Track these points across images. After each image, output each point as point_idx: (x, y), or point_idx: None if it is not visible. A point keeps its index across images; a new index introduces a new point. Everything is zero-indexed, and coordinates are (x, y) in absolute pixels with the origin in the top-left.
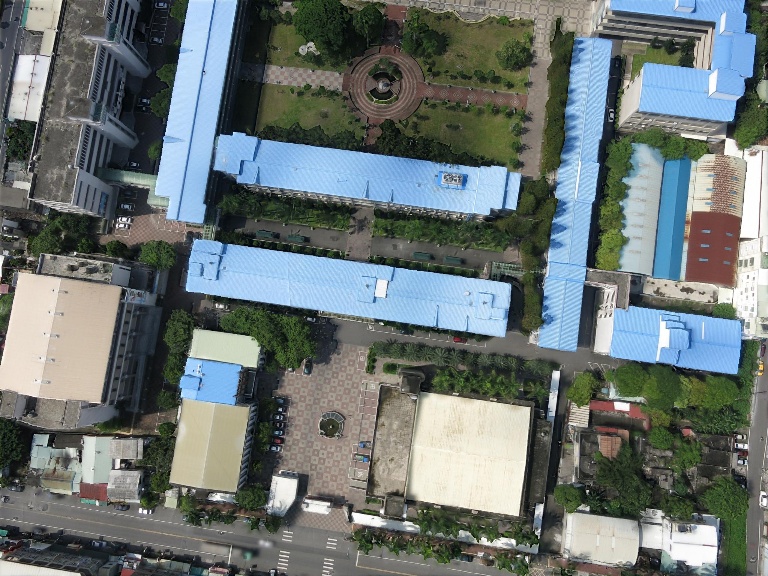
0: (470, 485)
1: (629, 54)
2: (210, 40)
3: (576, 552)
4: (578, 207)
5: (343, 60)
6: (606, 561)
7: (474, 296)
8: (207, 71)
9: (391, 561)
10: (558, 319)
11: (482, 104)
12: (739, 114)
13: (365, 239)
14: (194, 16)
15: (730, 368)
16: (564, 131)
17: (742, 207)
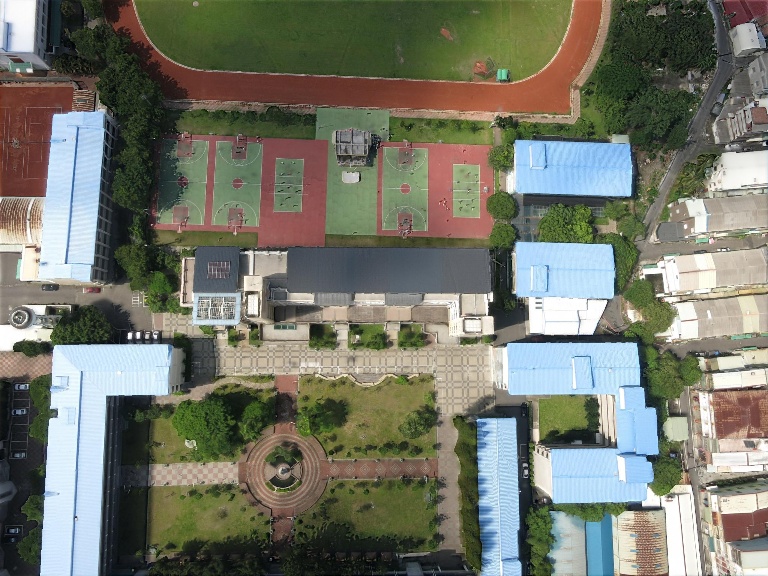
0: None
1: (534, 399)
2: (79, 478)
3: None
4: None
5: (236, 447)
6: None
7: None
8: (79, 516)
9: None
10: None
11: (392, 476)
12: None
13: None
14: (56, 451)
15: None
16: (480, 550)
17: (667, 560)
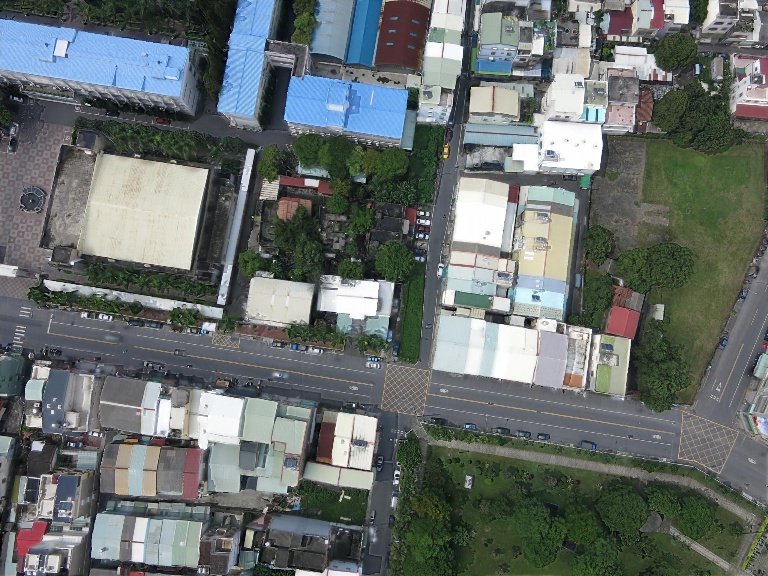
0: (144, 240)
1: None
2: None
3: (253, 311)
4: None
5: None
6: (282, 321)
7: (151, 57)
8: None
9: (82, 328)
10: (237, 86)
11: None
12: None
13: (78, 26)
14: None
15: (395, 132)
16: None
17: None
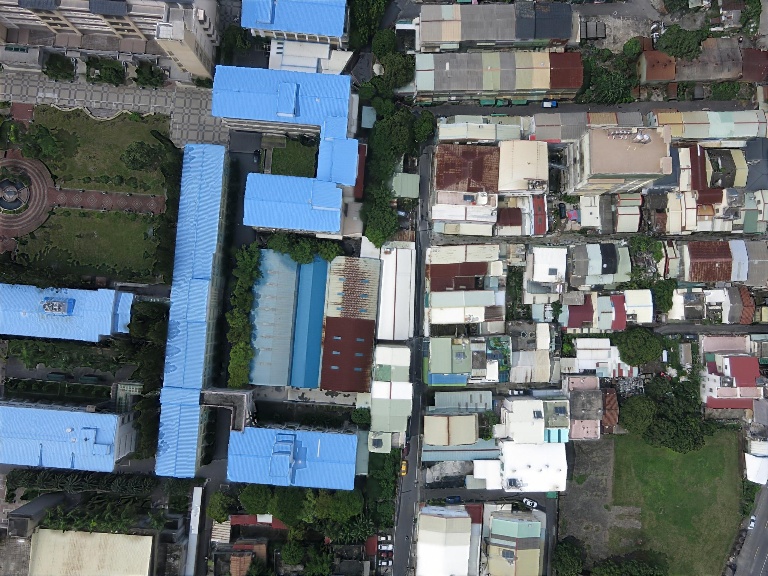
0: None
1: (269, 148)
2: None
3: None
4: (191, 327)
5: None
6: None
7: (77, 432)
8: None
9: None
10: (174, 446)
11: (118, 209)
12: (367, 214)
13: None
14: None
15: (346, 484)
16: None
17: (376, 309)
